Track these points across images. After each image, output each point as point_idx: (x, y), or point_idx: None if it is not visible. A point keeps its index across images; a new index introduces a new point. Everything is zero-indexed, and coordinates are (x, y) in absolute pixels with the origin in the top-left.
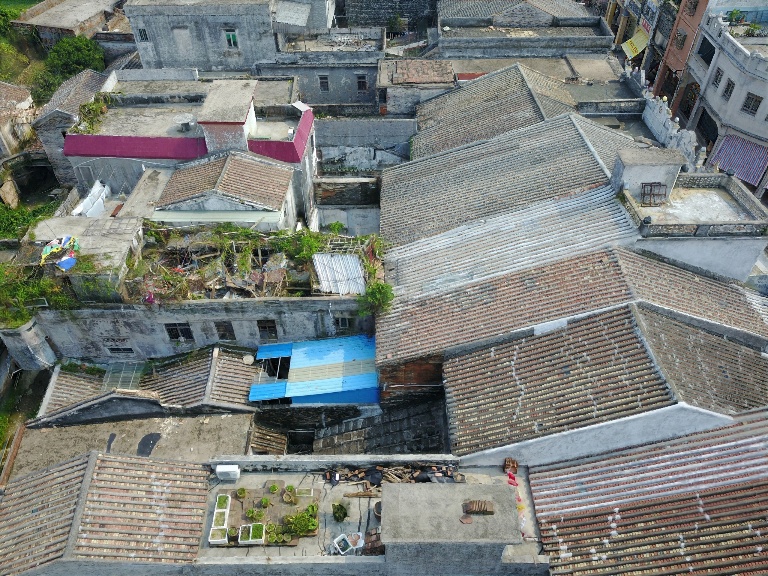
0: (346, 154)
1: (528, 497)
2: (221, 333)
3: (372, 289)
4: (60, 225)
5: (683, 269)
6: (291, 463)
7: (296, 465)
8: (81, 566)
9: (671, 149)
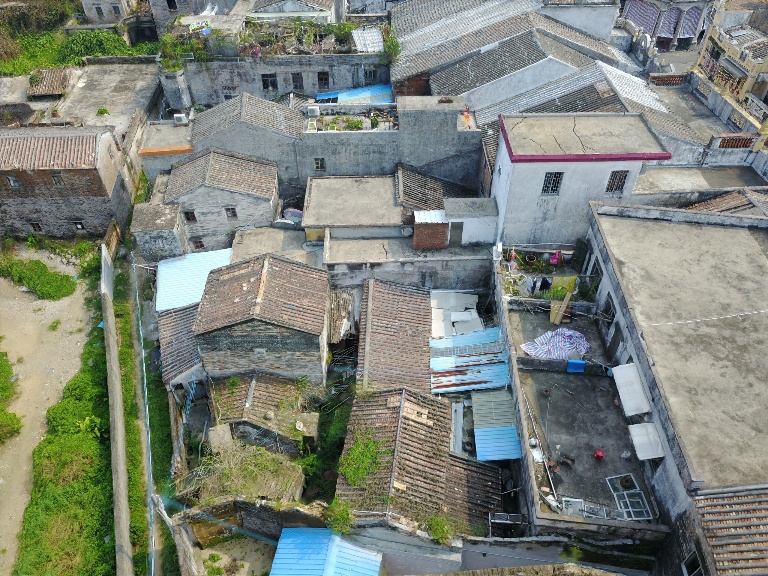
0: (366, 5)
1: (474, 121)
2: (295, 84)
3: (388, 45)
4: (195, 19)
5: (570, 28)
6: (347, 107)
7: (350, 109)
8: (248, 129)
9: None
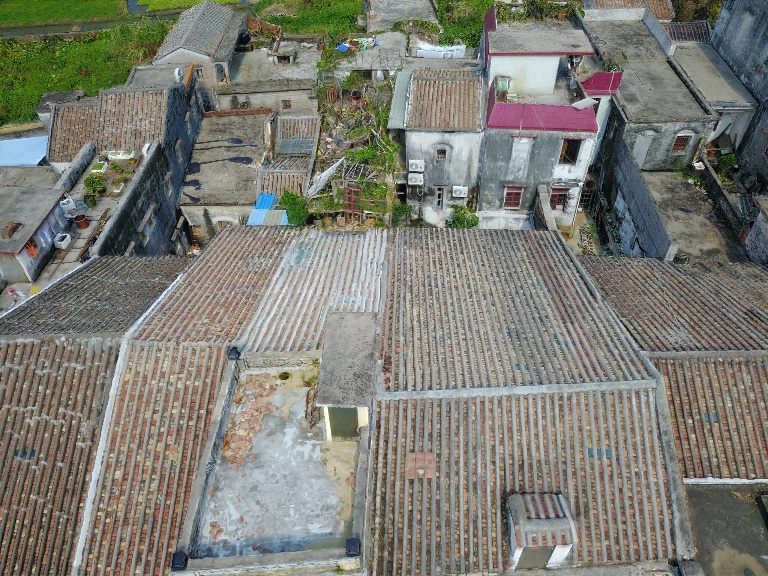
0: (625, 218)
1: None
2: None
3: (293, 197)
4: (394, 39)
5: None
6: None
7: None
8: None
9: (368, 390)
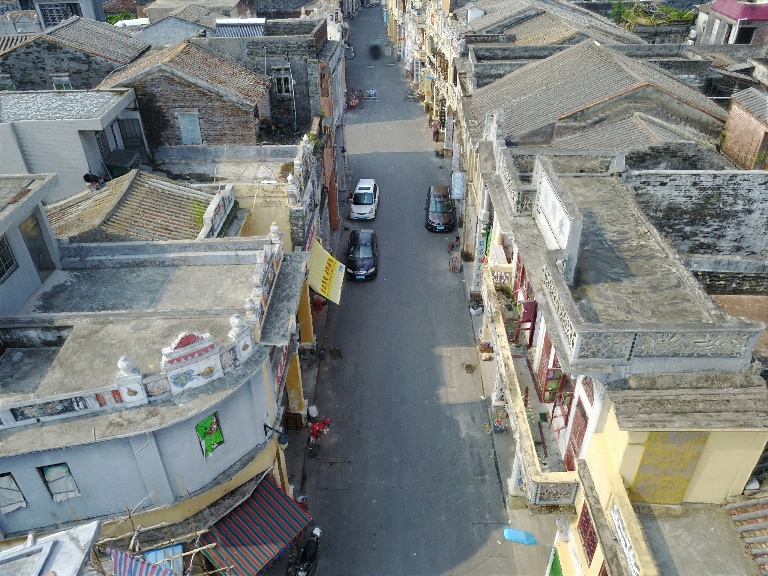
0: None
1: None
2: None
3: (622, 8)
4: None
5: None
6: None
7: None
8: None
9: None
